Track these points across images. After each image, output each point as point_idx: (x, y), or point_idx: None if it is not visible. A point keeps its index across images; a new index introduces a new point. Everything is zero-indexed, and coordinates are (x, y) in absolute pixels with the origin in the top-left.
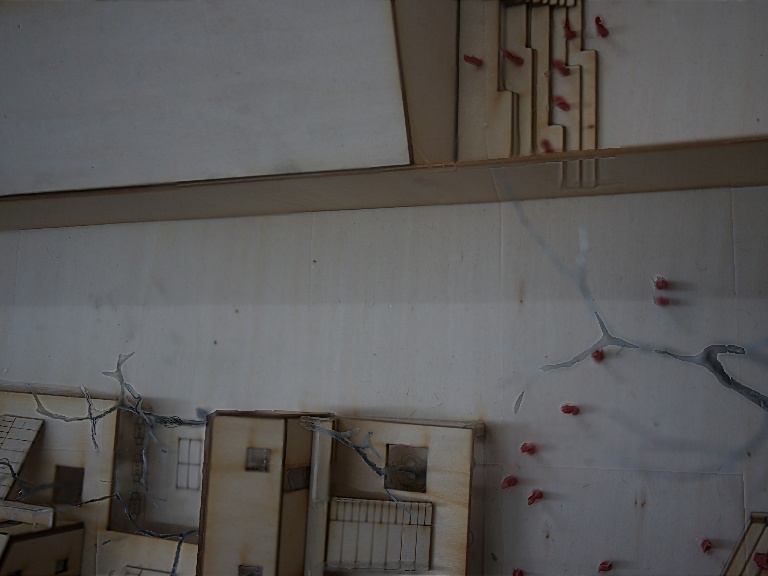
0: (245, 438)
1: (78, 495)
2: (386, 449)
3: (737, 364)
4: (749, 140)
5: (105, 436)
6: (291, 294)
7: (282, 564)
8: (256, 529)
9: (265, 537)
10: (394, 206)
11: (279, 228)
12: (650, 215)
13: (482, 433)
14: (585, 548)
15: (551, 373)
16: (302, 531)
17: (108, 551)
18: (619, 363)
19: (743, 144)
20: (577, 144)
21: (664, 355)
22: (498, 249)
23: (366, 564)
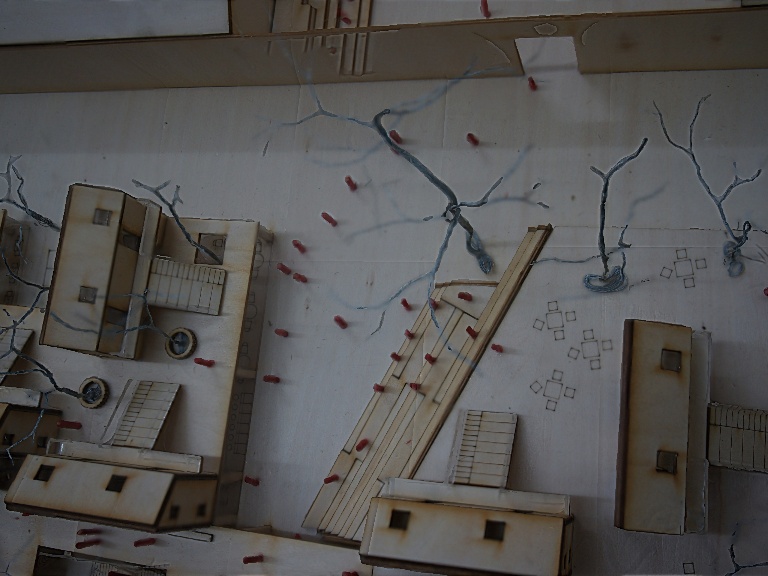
0: (95, 202)
1: None
2: (198, 237)
3: (439, 192)
4: (435, 25)
5: None
6: (146, 146)
7: (112, 291)
8: (96, 263)
9: (102, 269)
10: (227, 85)
11: (143, 99)
12: (396, 96)
13: (270, 239)
14: (331, 314)
15: (321, 199)
16: (130, 280)
17: None
18: (366, 192)
19: (432, 27)
20: (353, 46)
21: (395, 186)
22: (295, 116)
23: (173, 304)
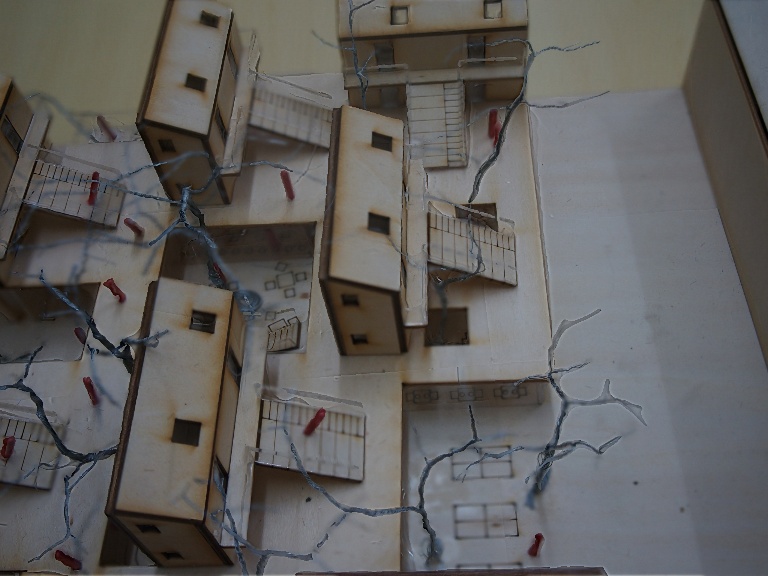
0: None
1: (433, 335)
2: None
3: None
4: None
5: (511, 367)
6: None
7: None
8: None
9: None
10: None
11: None
12: None
13: None
14: None
15: None
16: None
17: (379, 388)
18: None
19: None
20: None
21: None
22: None
23: None
